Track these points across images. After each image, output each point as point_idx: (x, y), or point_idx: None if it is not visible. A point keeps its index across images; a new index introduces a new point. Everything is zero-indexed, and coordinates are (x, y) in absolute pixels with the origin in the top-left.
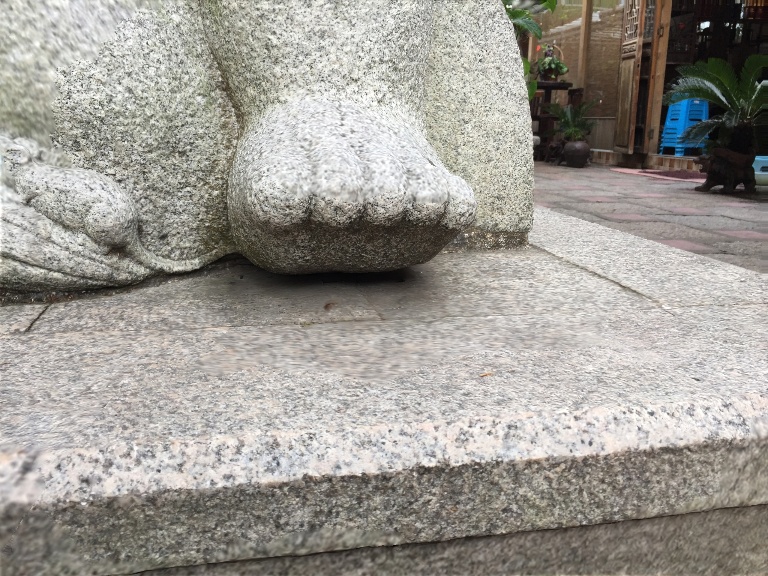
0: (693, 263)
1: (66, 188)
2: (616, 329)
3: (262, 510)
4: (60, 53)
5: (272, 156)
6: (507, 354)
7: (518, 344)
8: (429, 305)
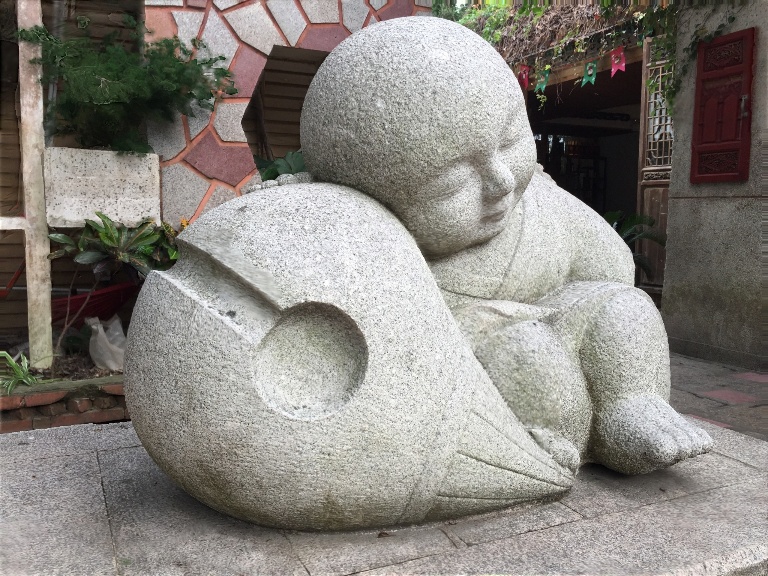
0: (748, 441)
1: (566, 449)
2: None
3: (755, 572)
4: (563, 392)
5: (658, 434)
6: (759, 507)
7: (755, 502)
8: None
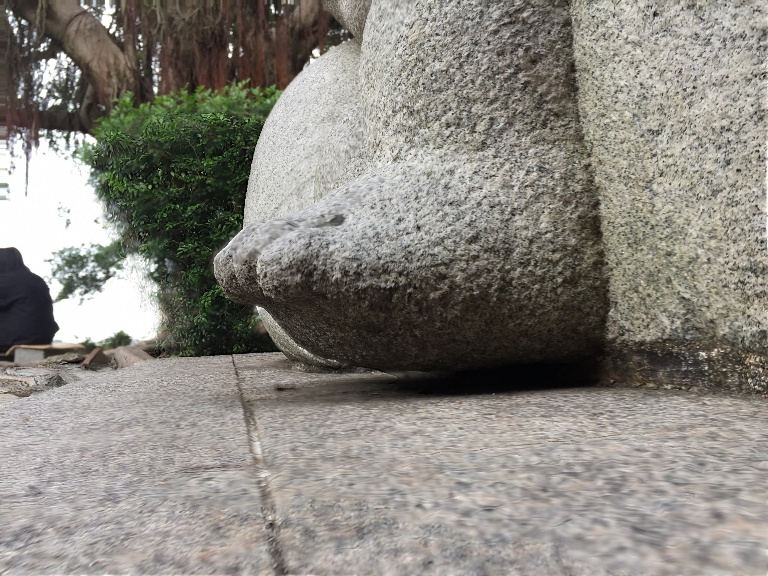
0: None
1: None
2: (130, 446)
3: None
4: None
5: None
6: None
7: None
8: (303, 404)
